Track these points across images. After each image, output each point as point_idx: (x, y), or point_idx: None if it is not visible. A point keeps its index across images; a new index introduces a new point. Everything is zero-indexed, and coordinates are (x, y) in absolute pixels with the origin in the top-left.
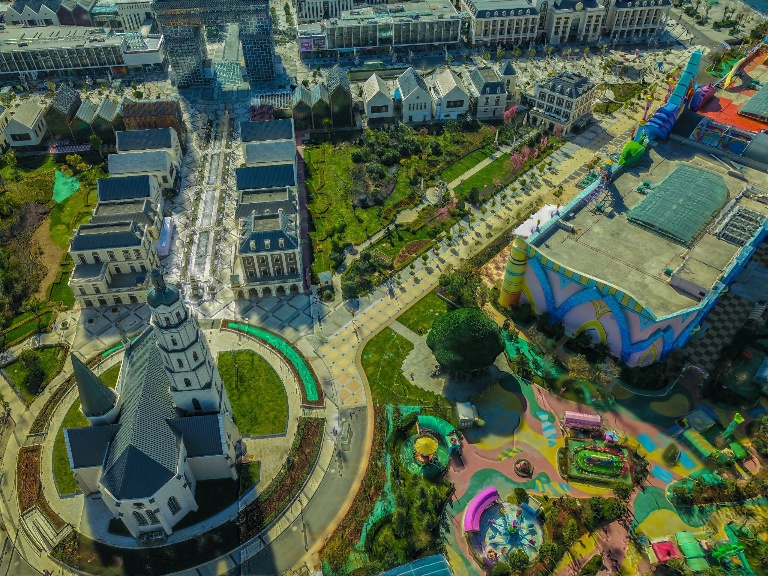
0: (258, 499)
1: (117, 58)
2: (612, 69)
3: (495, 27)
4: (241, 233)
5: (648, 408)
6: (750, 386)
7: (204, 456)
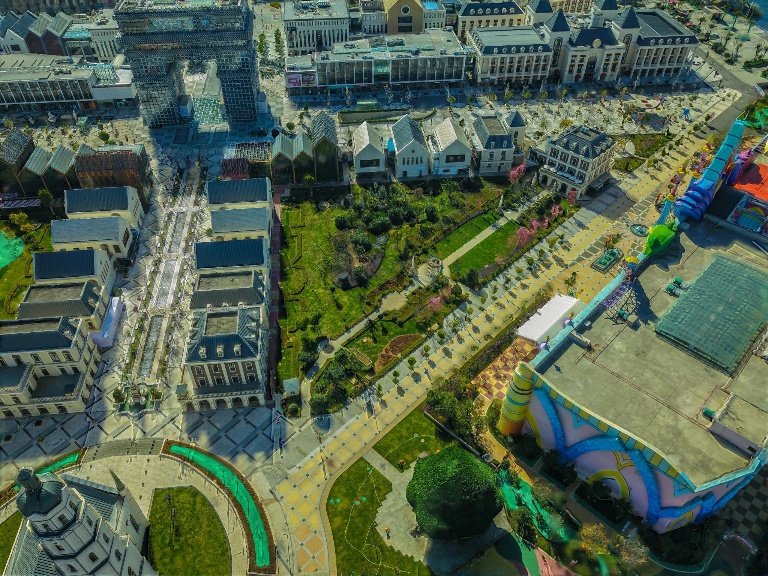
0: None
1: (85, 92)
2: (632, 116)
3: (503, 64)
4: (191, 334)
5: None
6: None
7: None
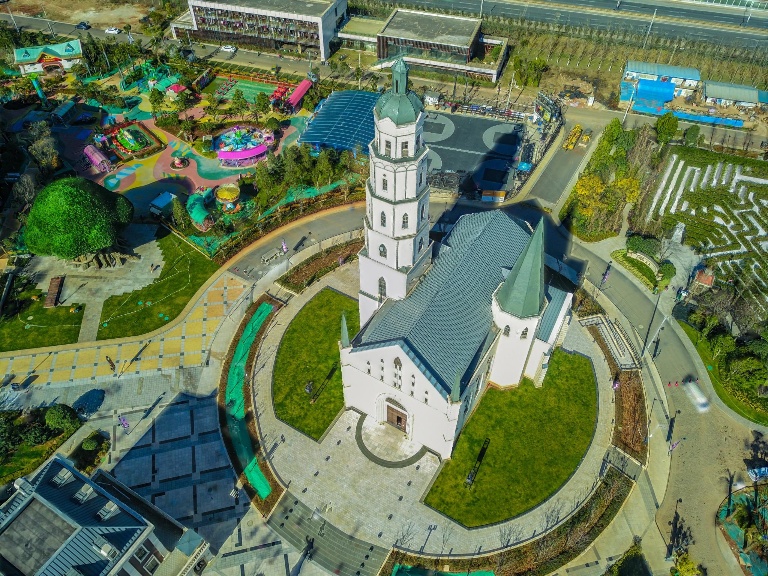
0: None
1: None
2: None
3: None
4: None
5: None
6: None
7: None
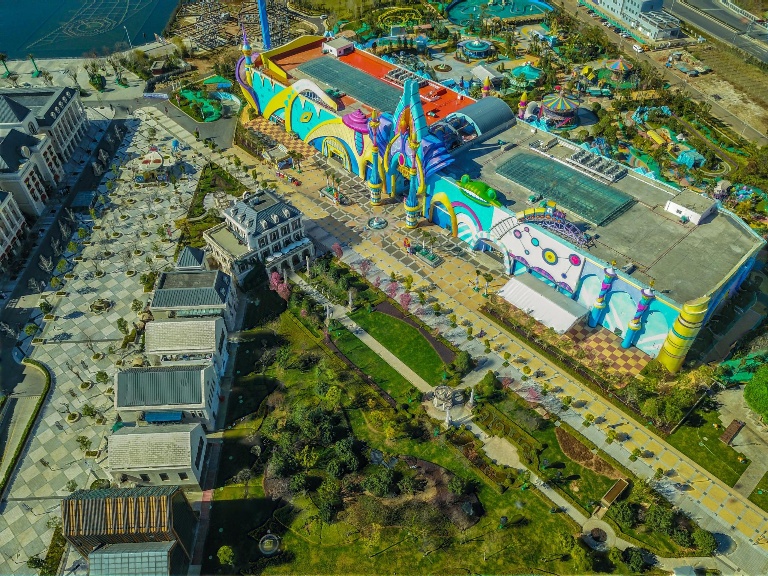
0: None
1: None
2: (163, 179)
3: None
4: None
5: None
6: None
7: None
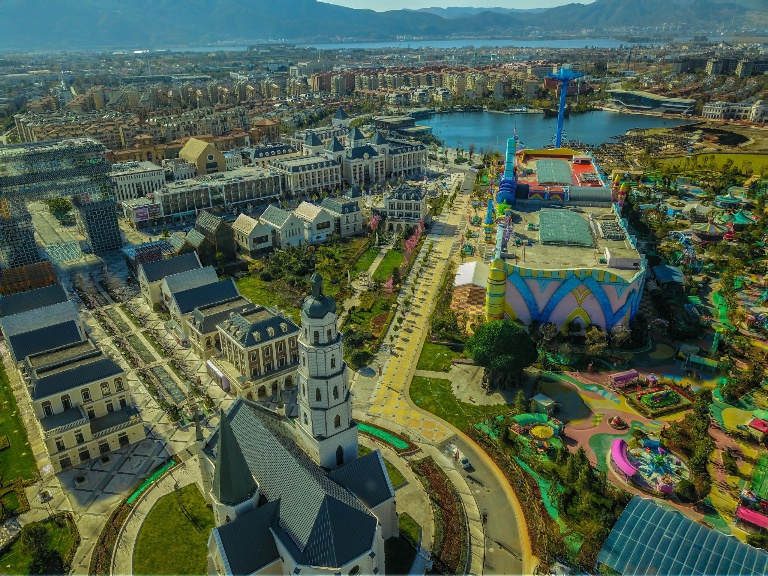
0: (437, 541)
1: None
2: None
3: (307, 179)
4: (233, 332)
5: (650, 358)
6: (691, 325)
7: (374, 507)
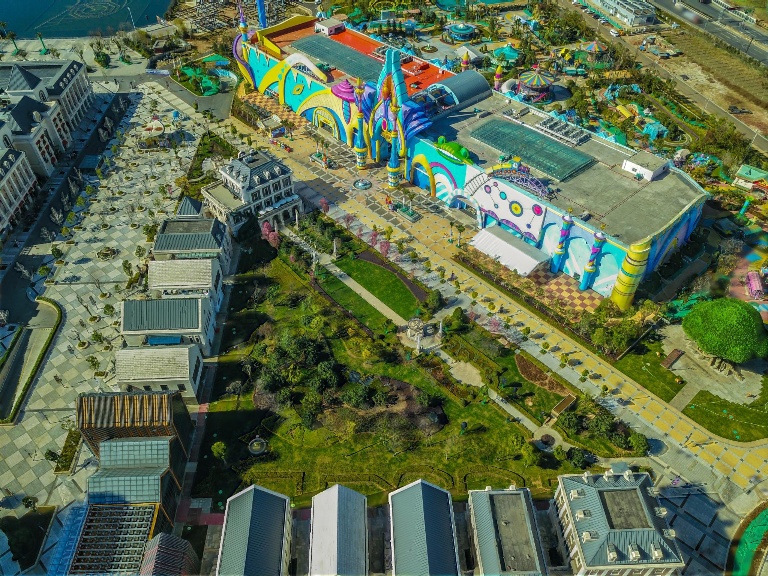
0: None
1: None
2: (164, 145)
3: None
4: (637, 558)
5: None
6: None
7: None
